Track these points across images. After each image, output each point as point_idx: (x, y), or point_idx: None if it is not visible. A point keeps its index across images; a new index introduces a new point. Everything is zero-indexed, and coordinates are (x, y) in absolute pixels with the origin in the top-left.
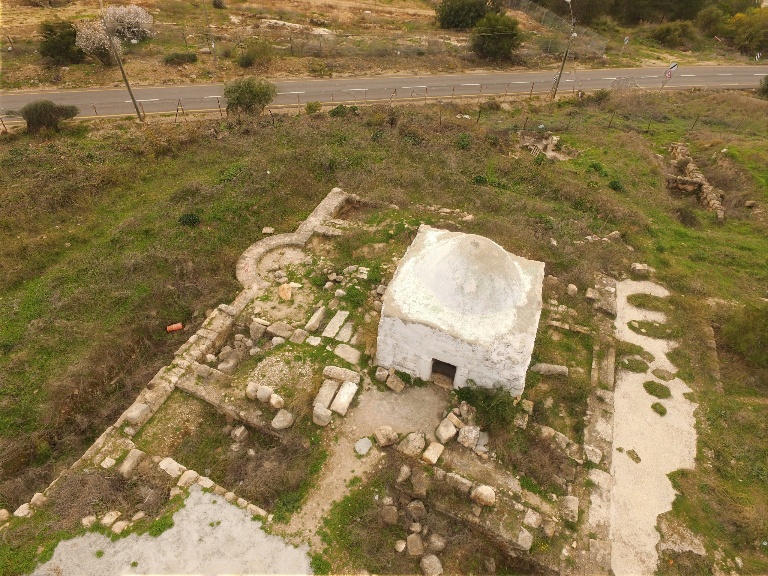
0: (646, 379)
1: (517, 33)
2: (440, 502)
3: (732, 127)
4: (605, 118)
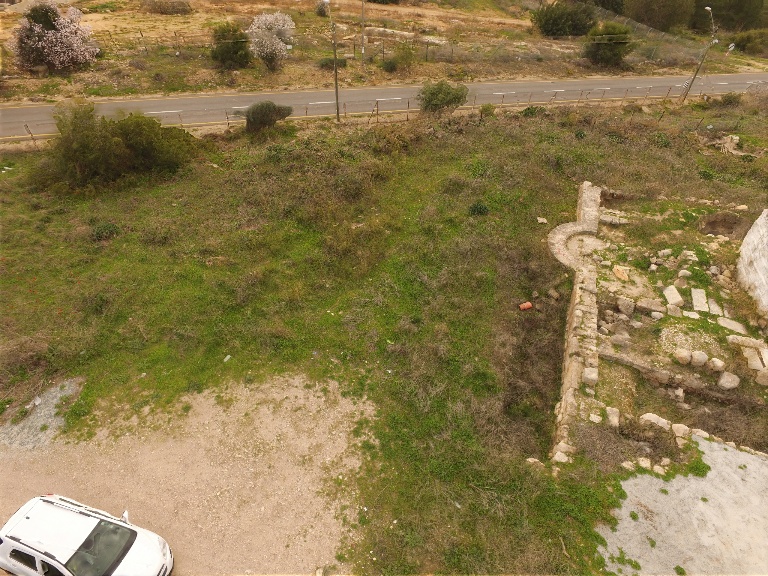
0: None
1: None
2: None
3: None
4: (760, 119)
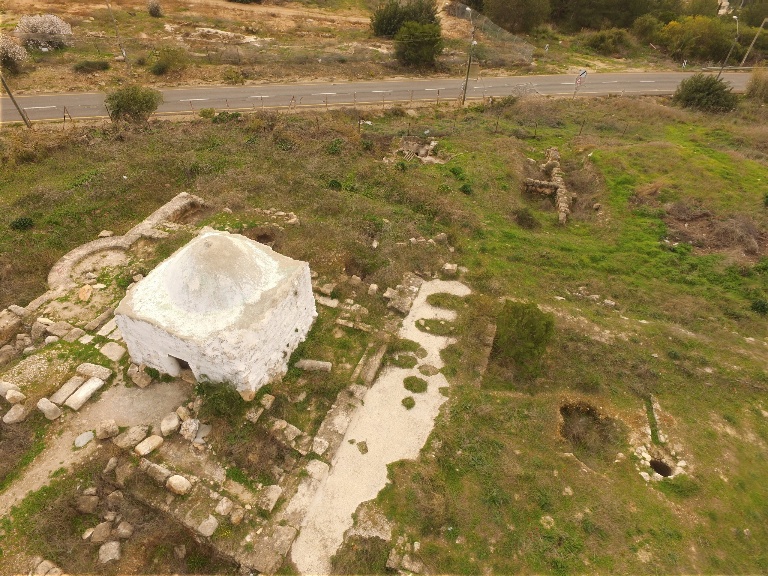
0: (409, 374)
1: (438, 41)
2: (139, 492)
3: (621, 132)
4: (495, 124)
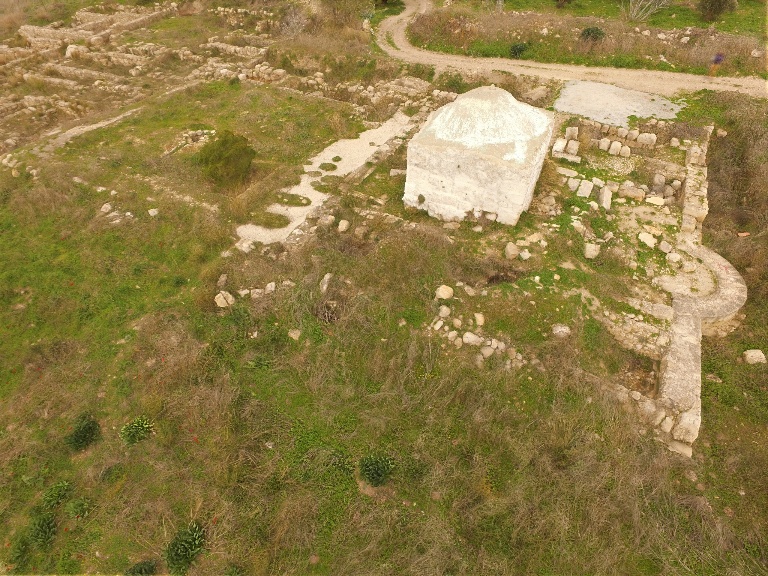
0: (331, 172)
1: None
2: None
3: None
4: None
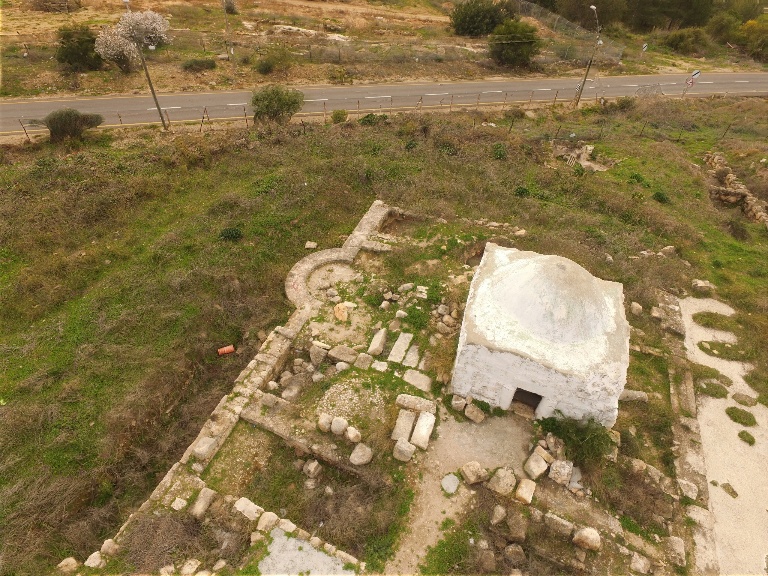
0: (727, 405)
1: None
2: (540, 546)
3: (762, 136)
4: (635, 127)
